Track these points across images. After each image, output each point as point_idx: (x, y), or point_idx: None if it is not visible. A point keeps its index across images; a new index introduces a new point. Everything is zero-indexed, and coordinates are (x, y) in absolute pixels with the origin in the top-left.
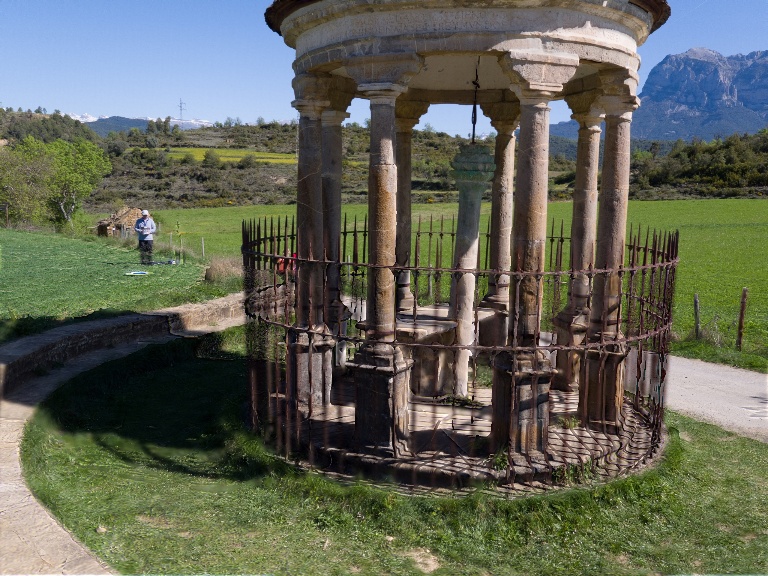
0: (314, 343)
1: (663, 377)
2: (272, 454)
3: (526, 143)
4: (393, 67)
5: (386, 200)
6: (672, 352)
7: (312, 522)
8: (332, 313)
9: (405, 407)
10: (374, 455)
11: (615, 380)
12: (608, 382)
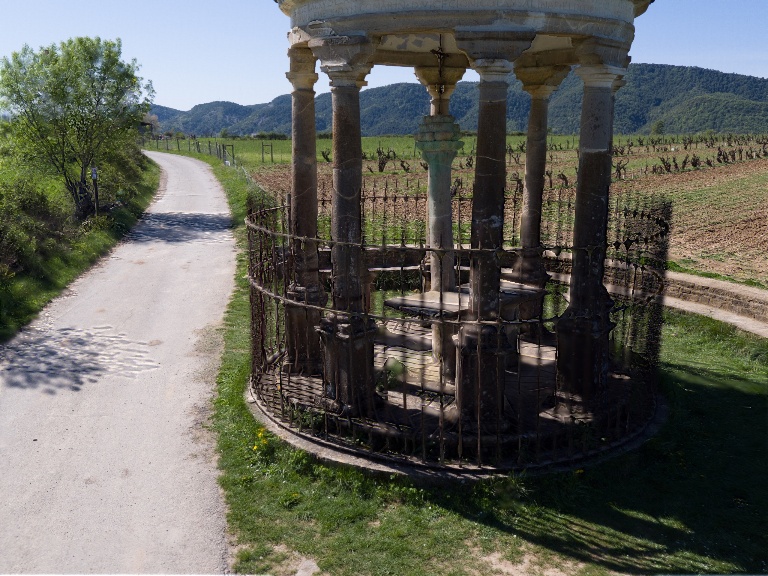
0: None
1: None
2: None
3: None
4: None
5: None
6: None
7: None
8: None
9: None
10: None
11: None
12: None
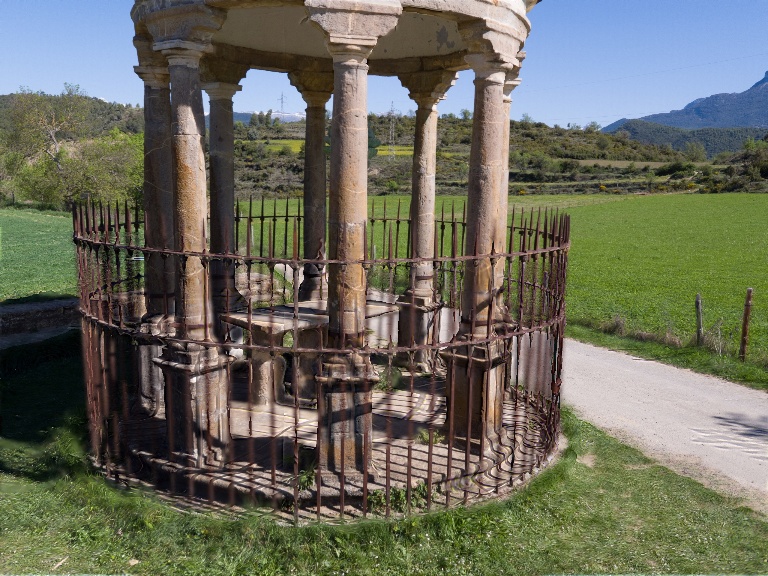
0: (159, 334)
1: (554, 390)
2: (87, 454)
3: (336, 108)
4: (182, 21)
5: (186, 175)
6: (662, 359)
7: (69, 535)
8: (220, 303)
9: (221, 410)
10: (177, 463)
11: (481, 391)
12: (474, 393)
